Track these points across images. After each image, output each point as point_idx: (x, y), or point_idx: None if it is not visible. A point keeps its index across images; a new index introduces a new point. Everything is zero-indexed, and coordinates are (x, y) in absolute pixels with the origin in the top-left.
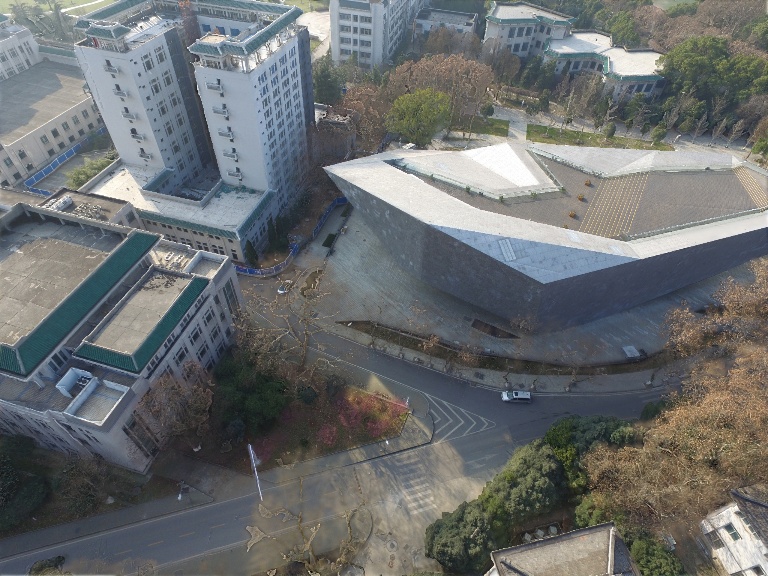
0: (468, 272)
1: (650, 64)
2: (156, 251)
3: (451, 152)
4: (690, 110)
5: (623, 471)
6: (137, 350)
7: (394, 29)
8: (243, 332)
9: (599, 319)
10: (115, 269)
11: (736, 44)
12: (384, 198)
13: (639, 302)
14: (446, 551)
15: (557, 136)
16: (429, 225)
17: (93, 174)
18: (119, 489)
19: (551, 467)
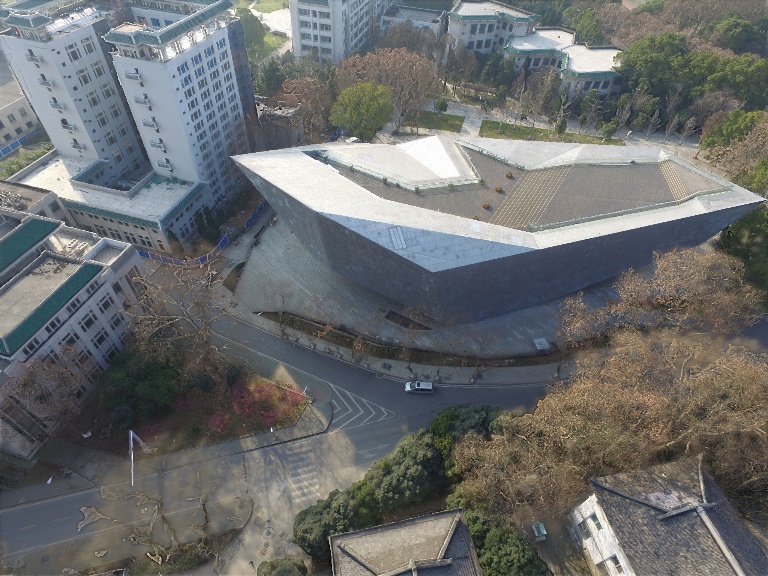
0: (367, 261)
1: (609, 61)
2: (62, 238)
3: (385, 145)
4: (645, 107)
5: (483, 458)
6: (10, 333)
7: (358, 25)
8: (137, 319)
9: (515, 312)
10: (5, 254)
11: (693, 41)
12: (281, 186)
13: (556, 295)
14: (305, 537)
15: (510, 132)
16: (317, 212)
17: (26, 164)
18: (1, 473)
19: (426, 455)
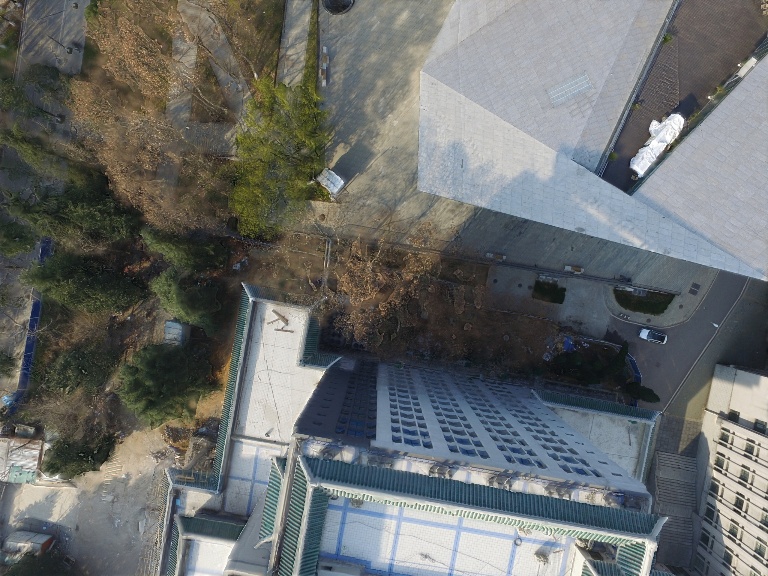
0: None
1: None
2: None
3: (440, 83)
4: None
5: None
6: None
7: None
8: None
9: None
10: None
11: None
12: None
13: None
14: None
15: None
16: None
17: None
18: None
19: None
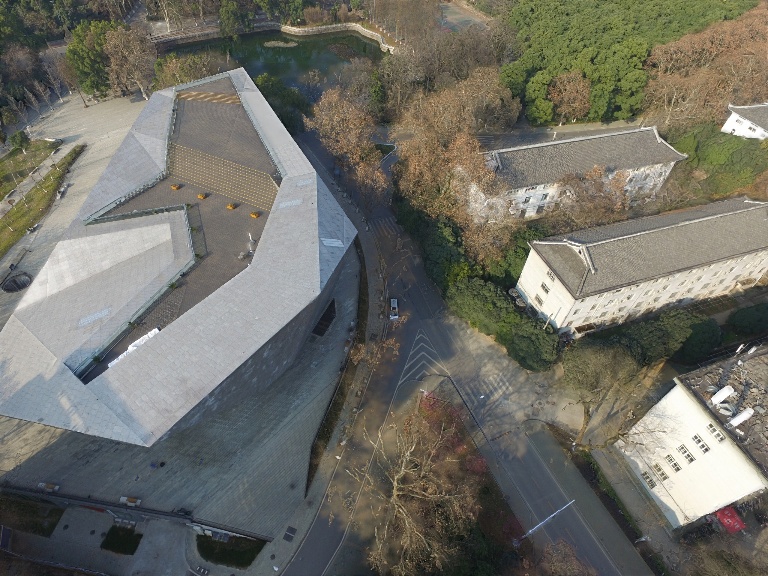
0: None
1: None
2: None
3: (17, 320)
4: None
5: (493, 231)
6: None
7: None
8: (419, 567)
9: None
10: None
11: None
12: (258, 343)
13: None
14: None
15: None
16: None
17: None
18: None
19: None
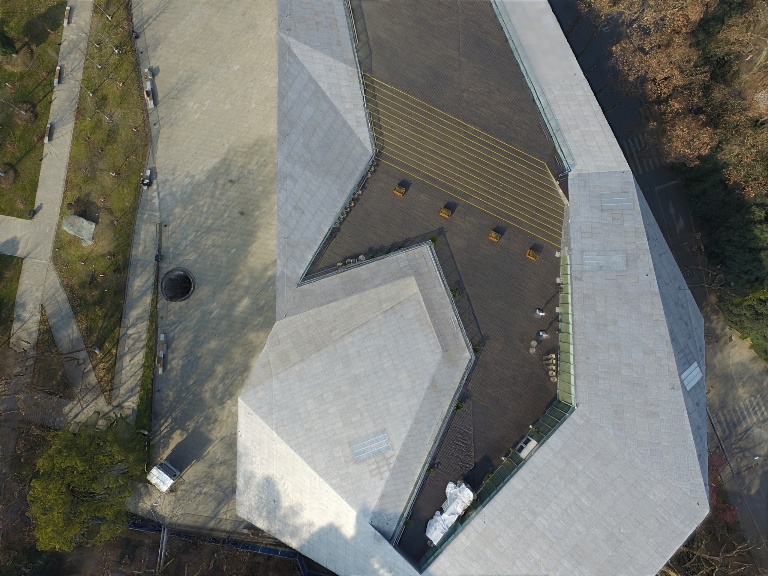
0: None
1: None
2: None
3: (255, 415)
4: None
5: None
6: None
7: None
8: None
9: None
10: None
11: None
12: None
13: None
14: None
15: (5, 152)
16: None
17: None
18: None
19: None
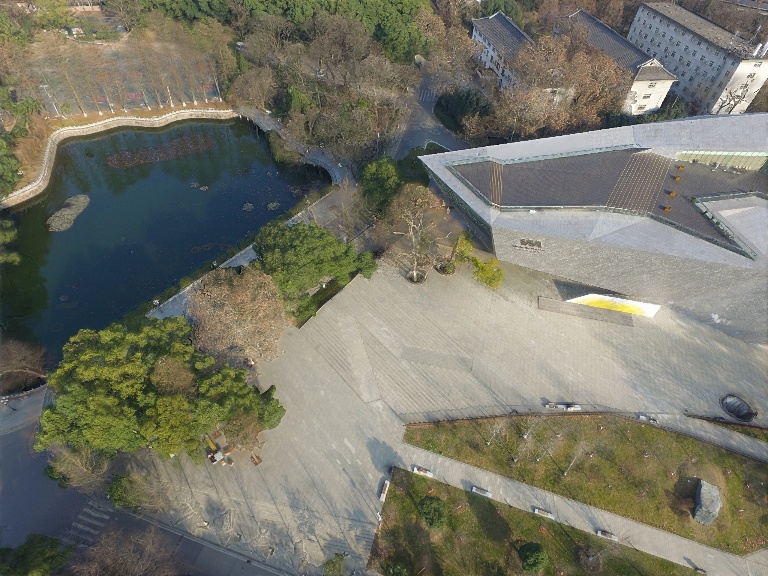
0: None
1: None
2: None
3: None
4: None
5: None
6: None
7: None
8: None
9: None
10: None
11: None
12: None
13: None
14: None
15: None
16: None
17: None
18: None
19: None
